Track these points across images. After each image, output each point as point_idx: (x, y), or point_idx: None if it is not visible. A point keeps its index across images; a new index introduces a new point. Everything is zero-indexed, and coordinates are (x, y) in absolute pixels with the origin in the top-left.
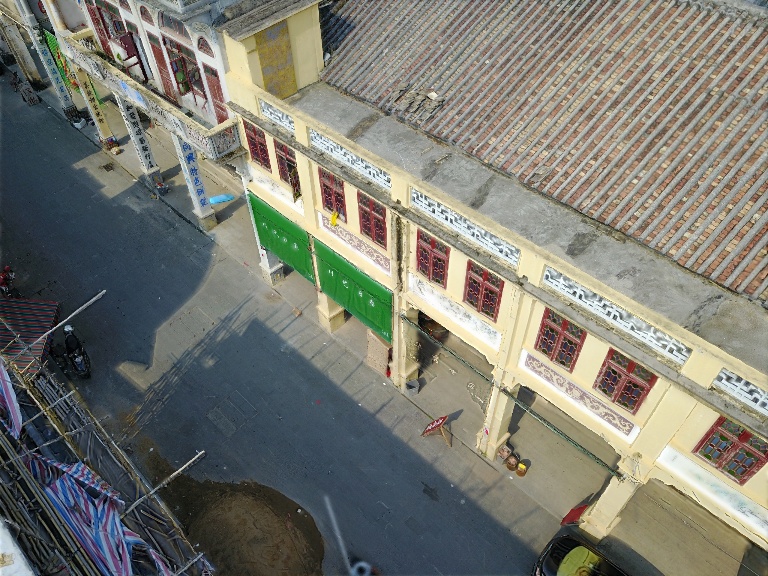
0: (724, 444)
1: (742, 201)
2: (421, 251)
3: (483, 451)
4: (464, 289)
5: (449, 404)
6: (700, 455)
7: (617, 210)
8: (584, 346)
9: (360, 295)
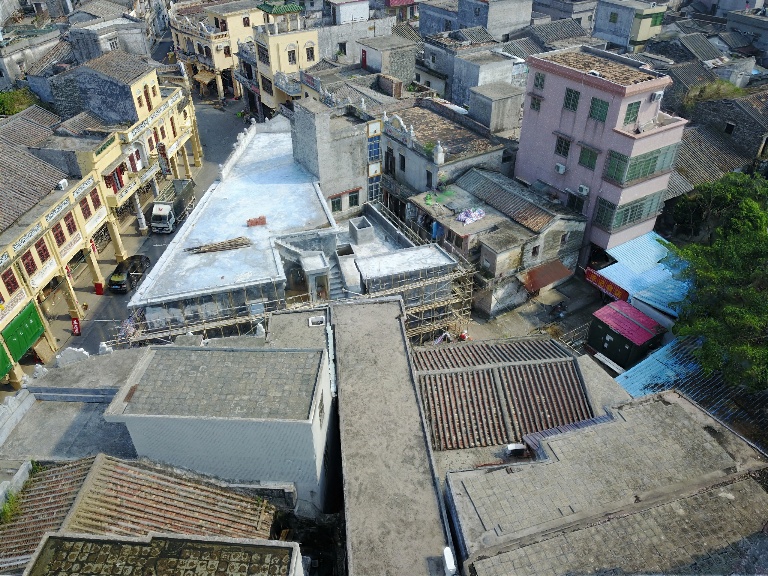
0: None
1: (7, 195)
2: None
3: None
4: None
5: (61, 334)
6: (86, 220)
7: None
8: None
9: None
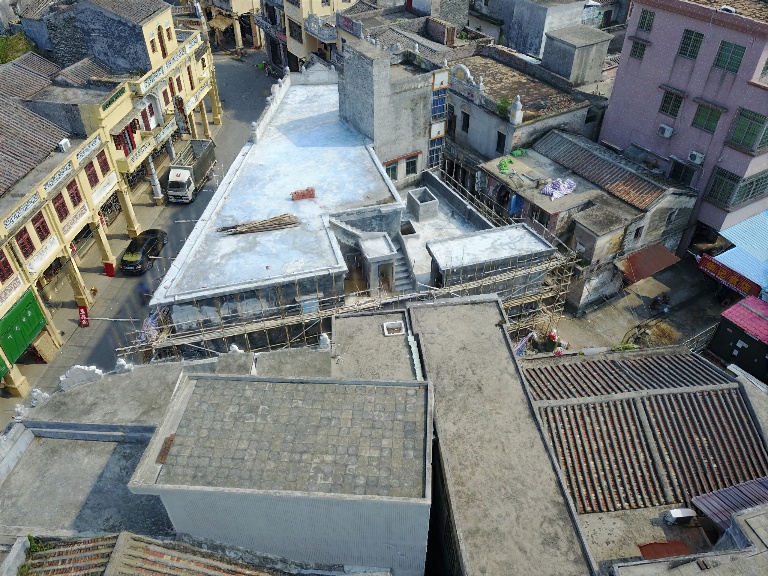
0: (90, 177)
1: None
2: (21, 247)
3: (90, 302)
4: (38, 238)
5: (66, 325)
6: None
7: (1, 184)
8: (64, 198)
9: (24, 321)
